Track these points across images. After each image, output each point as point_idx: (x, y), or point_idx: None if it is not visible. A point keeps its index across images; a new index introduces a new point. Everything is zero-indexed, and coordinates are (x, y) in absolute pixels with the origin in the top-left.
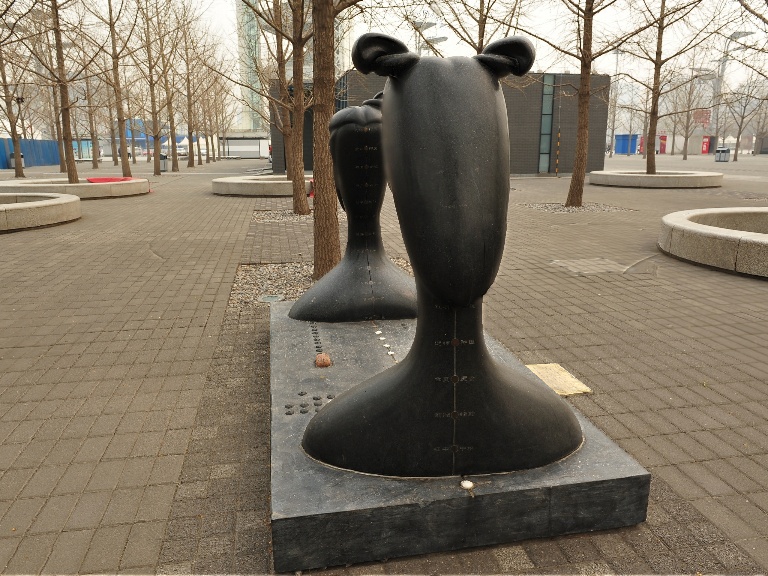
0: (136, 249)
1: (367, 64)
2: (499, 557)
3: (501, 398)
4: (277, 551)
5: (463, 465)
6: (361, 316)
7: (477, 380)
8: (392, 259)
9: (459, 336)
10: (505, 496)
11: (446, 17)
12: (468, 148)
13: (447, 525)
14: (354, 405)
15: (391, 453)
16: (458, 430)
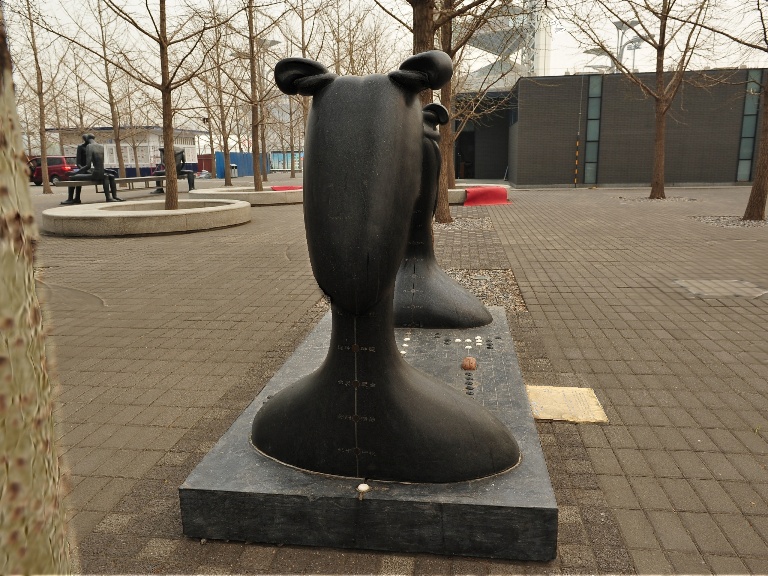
0: (274, 251)
1: (286, 86)
2: (385, 563)
3: (404, 408)
4: (185, 517)
5: (366, 469)
6: (400, 323)
7: (378, 387)
8: (499, 270)
9: (359, 343)
10: (393, 504)
11: (561, 21)
12: (359, 162)
13: (336, 522)
14: (281, 399)
15: (302, 447)
16: (359, 434)
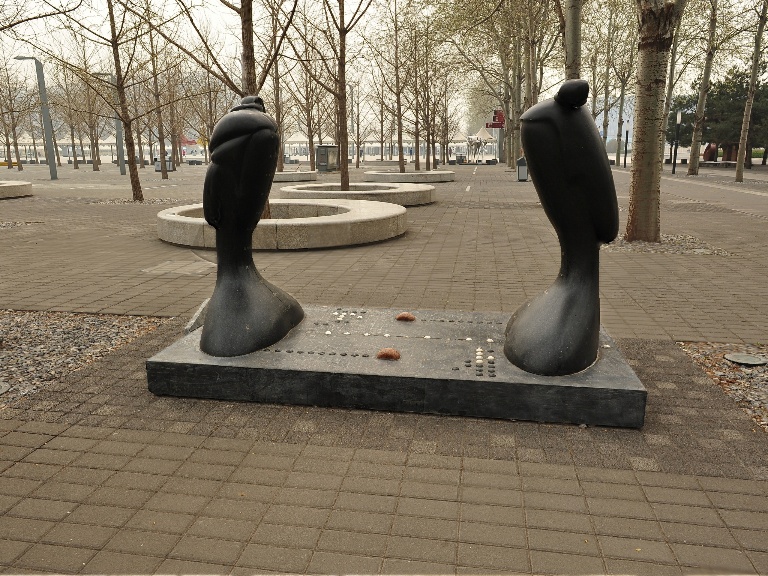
0: None
1: None
2: None
3: None
4: None
5: None
6: None
7: None
8: None
9: None
10: None
11: None
12: None
13: None
14: (579, 326)
15: None
16: None
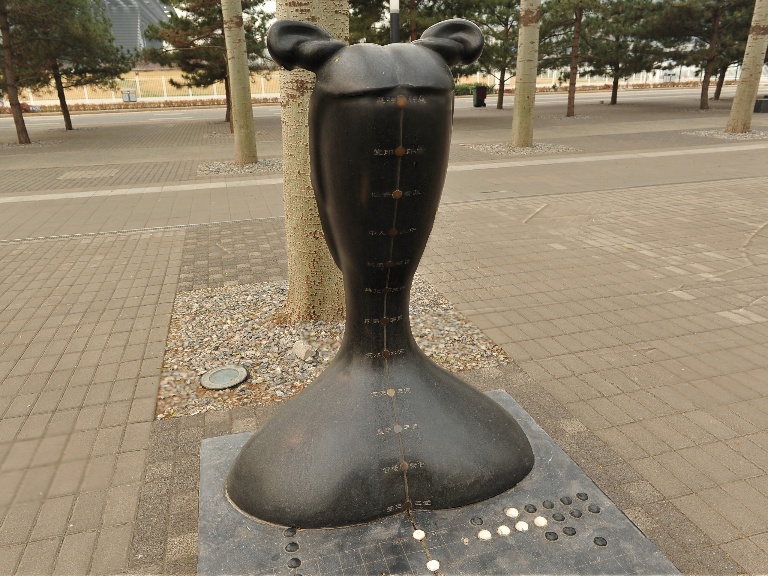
0: None
1: None
2: None
3: None
4: None
5: None
6: None
7: None
8: None
9: None
10: None
11: None
12: None
13: None
14: None
15: None
16: None
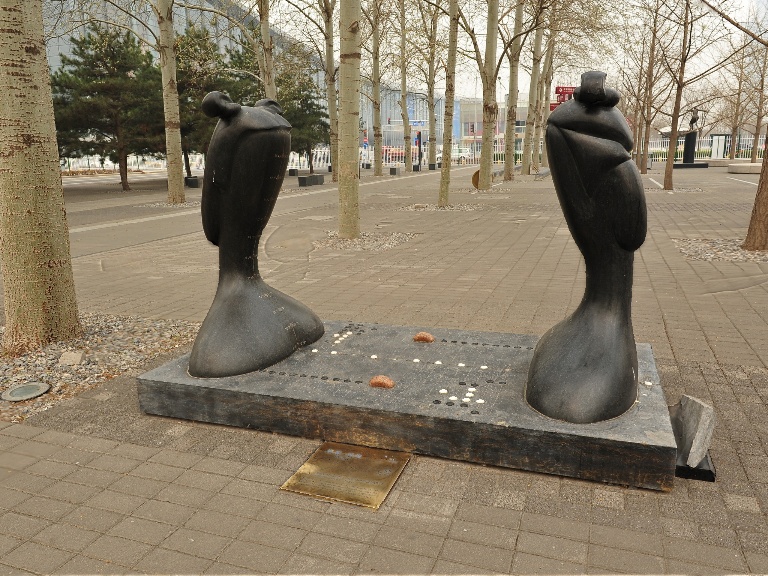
0: None
1: None
2: None
3: None
4: None
5: None
6: None
7: None
8: None
9: None
10: None
11: None
12: None
13: None
14: None
15: None
16: None
